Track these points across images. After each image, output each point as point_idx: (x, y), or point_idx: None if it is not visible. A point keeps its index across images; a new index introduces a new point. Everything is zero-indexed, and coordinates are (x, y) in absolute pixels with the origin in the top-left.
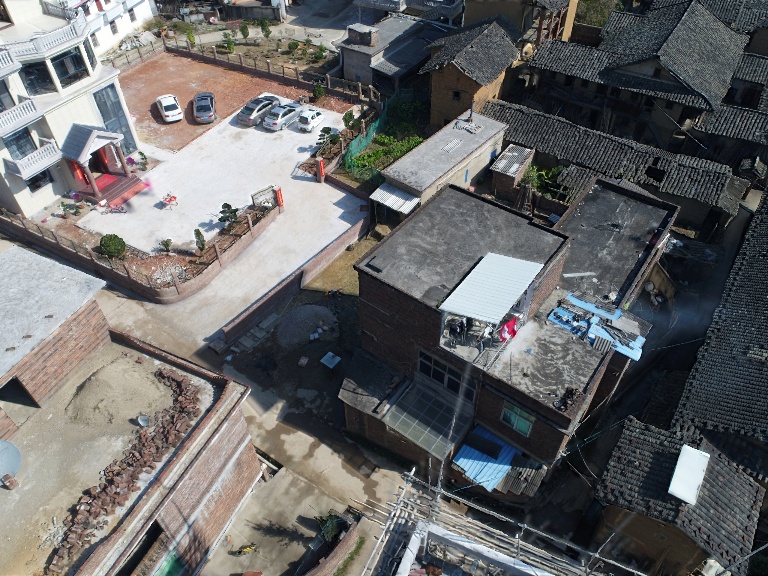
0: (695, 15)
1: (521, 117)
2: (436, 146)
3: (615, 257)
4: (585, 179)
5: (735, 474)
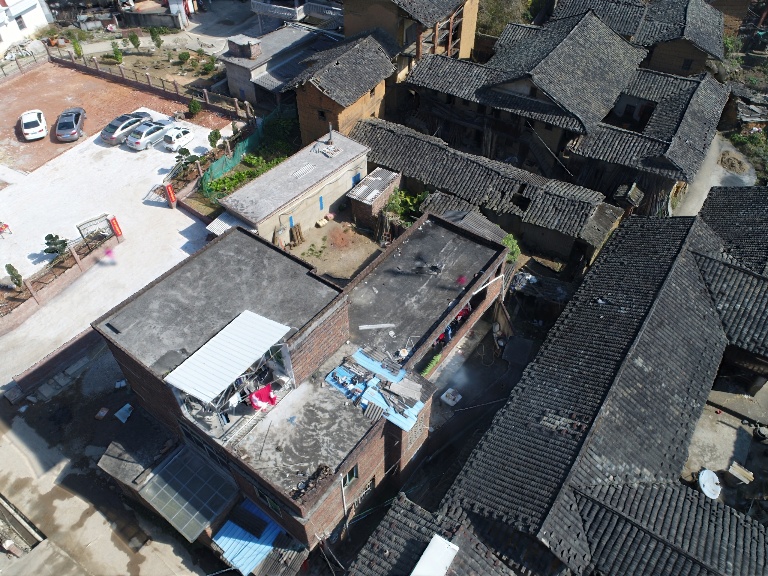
0: (587, 28)
1: (391, 138)
2: (286, 171)
3: (422, 306)
4: (448, 207)
5: (492, 567)
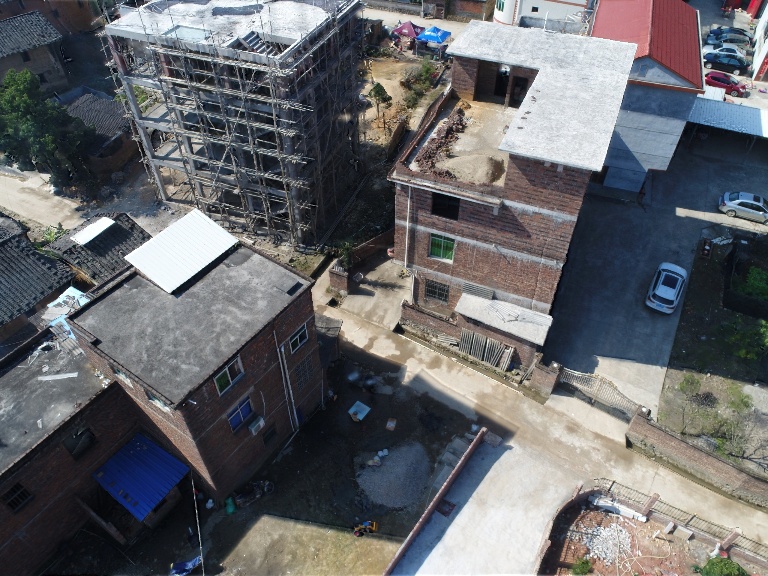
0: None
1: None
2: None
3: None
4: None
5: None
